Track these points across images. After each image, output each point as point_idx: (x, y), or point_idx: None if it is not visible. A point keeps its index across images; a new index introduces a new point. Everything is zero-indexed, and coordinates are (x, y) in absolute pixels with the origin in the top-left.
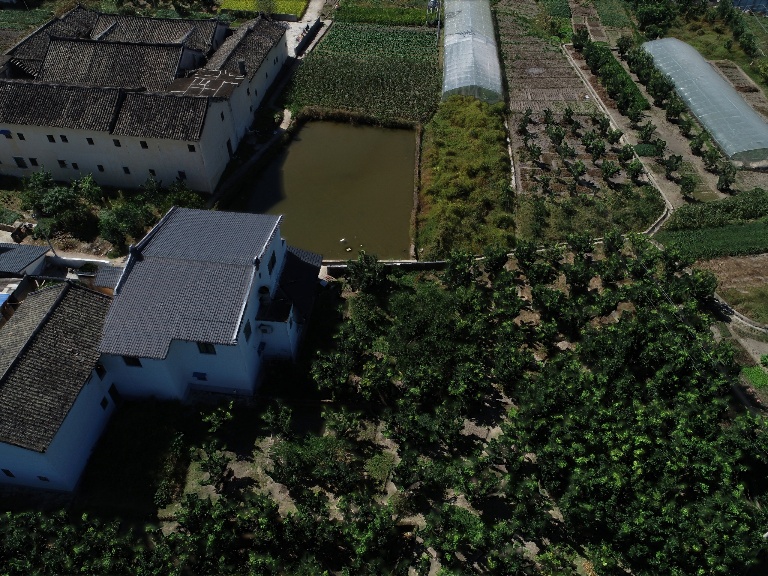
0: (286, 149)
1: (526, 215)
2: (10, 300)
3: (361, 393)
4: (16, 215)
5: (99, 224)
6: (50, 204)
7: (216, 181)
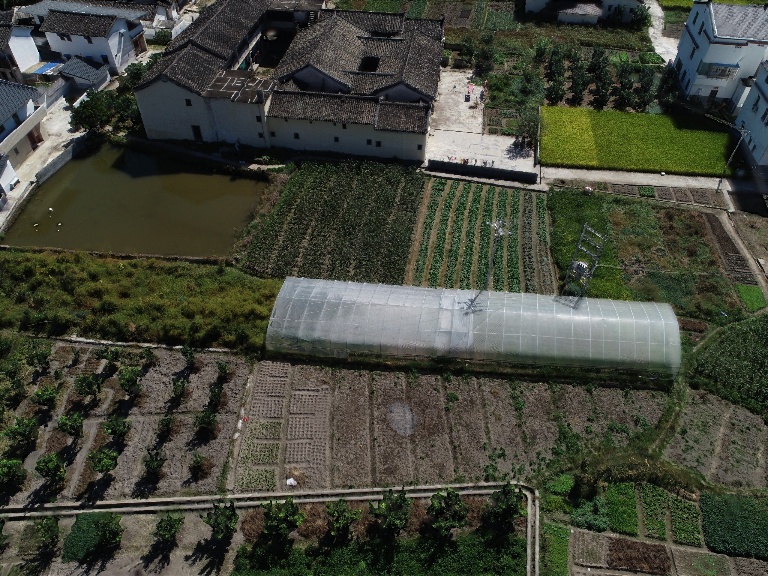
0: (214, 172)
1: (0, 335)
2: (47, 78)
3: None
4: None
5: None
6: None
7: (161, 136)
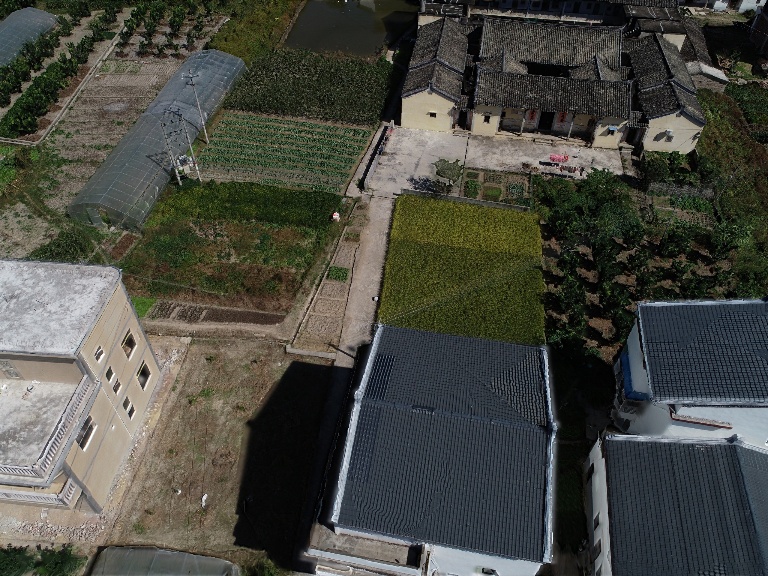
0: None
1: (234, 2)
2: None
3: None
4: None
5: None
6: None
7: None
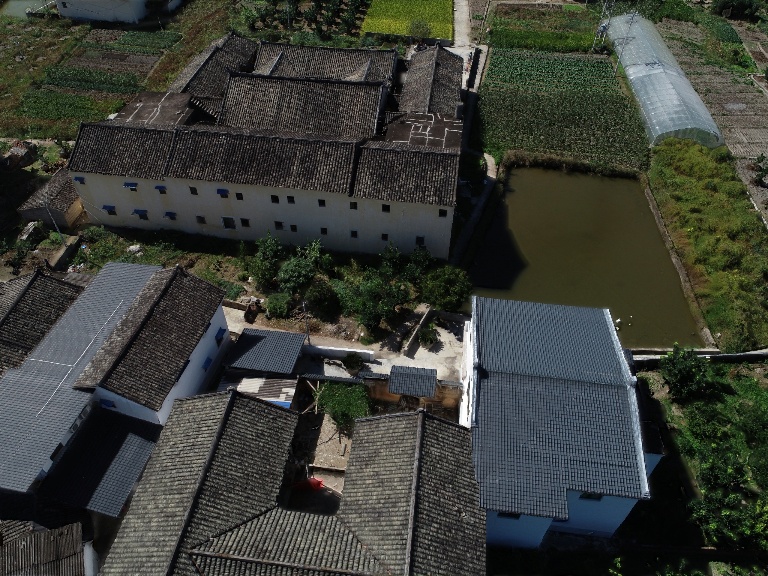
0: (504, 202)
1: None
2: None
3: (748, 538)
4: (238, 288)
5: (341, 301)
6: (292, 280)
7: None
